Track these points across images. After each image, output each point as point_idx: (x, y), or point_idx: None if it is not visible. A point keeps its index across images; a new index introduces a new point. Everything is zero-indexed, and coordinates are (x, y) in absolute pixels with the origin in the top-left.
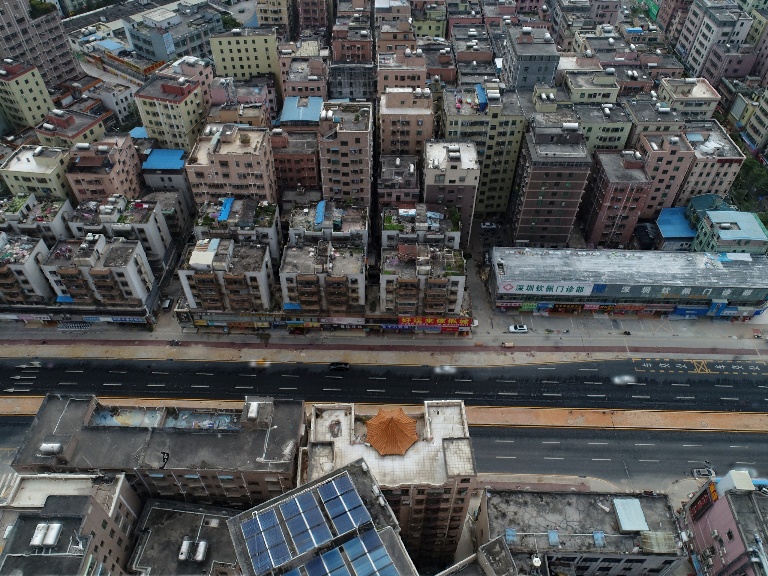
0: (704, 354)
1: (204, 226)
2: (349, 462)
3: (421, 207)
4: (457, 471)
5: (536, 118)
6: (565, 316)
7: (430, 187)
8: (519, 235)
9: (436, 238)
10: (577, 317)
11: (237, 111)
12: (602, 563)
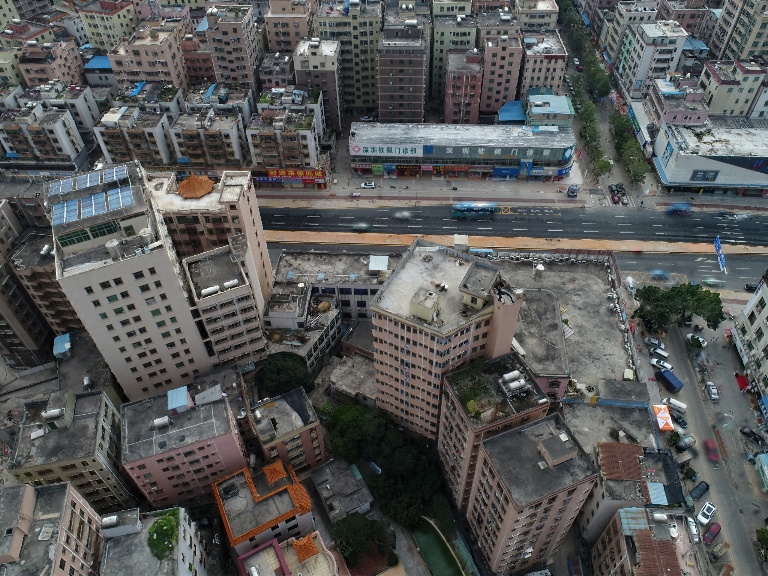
0: (512, 202)
1: (120, 101)
2: (162, 202)
3: (290, 87)
4: (227, 200)
5: (388, 19)
6: (409, 178)
7: (299, 72)
8: (382, 119)
9: (298, 109)
10: (419, 179)
11: (158, 22)
12: (356, 296)
